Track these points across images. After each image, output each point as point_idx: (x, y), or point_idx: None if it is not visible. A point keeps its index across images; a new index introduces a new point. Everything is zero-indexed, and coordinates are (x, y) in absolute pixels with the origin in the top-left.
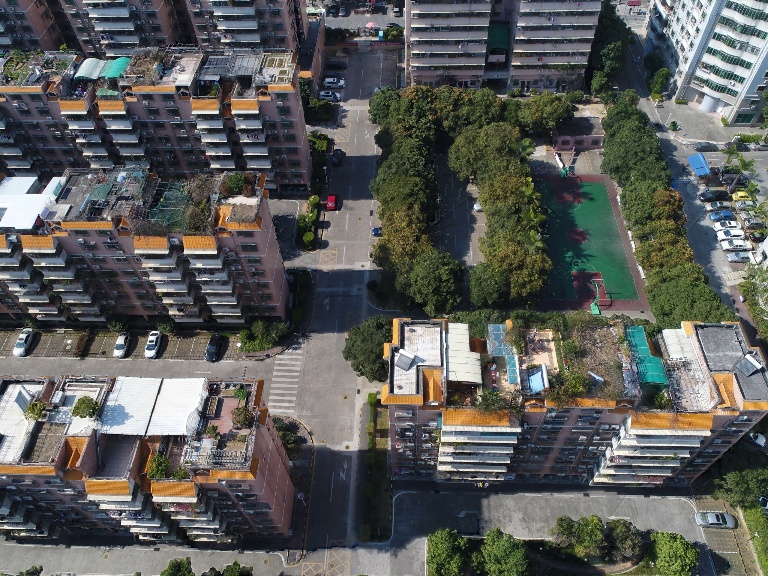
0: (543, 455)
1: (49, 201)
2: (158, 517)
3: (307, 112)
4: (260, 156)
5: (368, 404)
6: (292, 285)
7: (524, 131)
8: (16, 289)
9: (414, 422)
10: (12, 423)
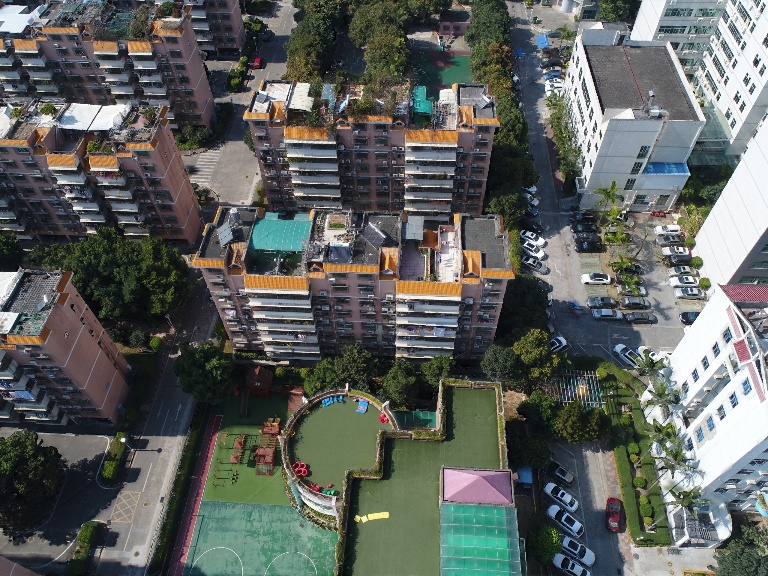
0: (367, 187)
1: (35, 17)
2: (97, 204)
3: (249, 5)
4: (200, 19)
5: None
6: (219, 112)
7: (416, 20)
8: (10, 90)
9: (270, 145)
10: (2, 123)
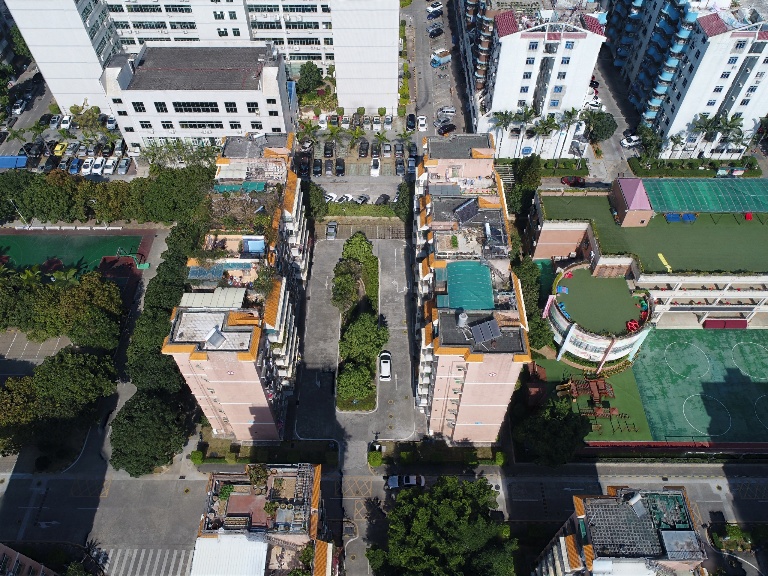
0: None
1: None
2: None
3: None
4: None
5: (201, 464)
6: None
7: None
8: None
9: None
10: None
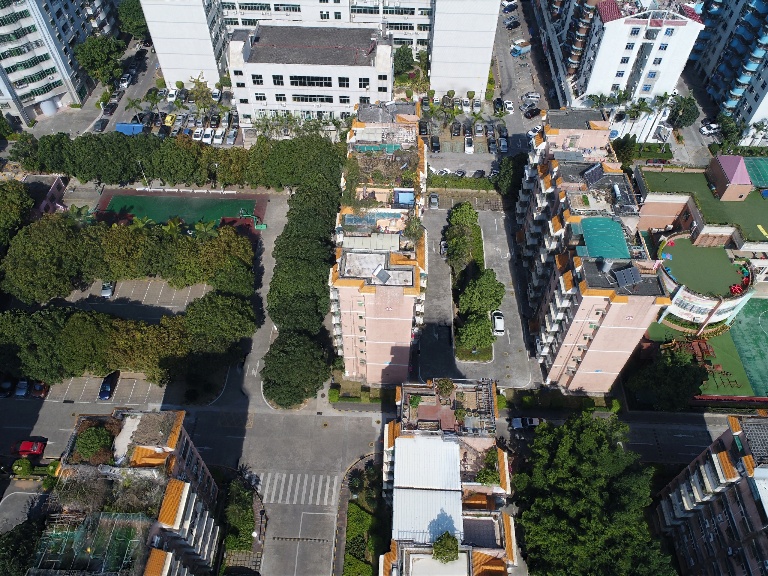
0: None
1: None
2: None
3: None
4: None
5: (337, 401)
6: None
7: None
8: None
9: None
10: None
